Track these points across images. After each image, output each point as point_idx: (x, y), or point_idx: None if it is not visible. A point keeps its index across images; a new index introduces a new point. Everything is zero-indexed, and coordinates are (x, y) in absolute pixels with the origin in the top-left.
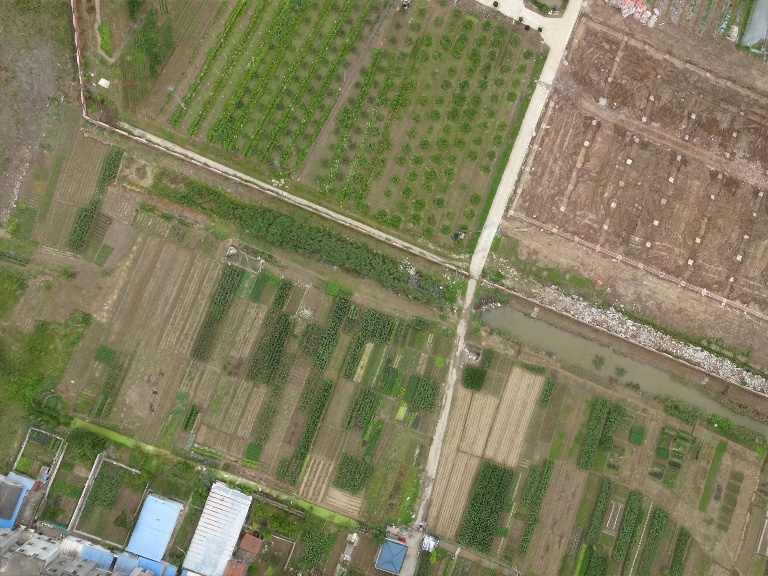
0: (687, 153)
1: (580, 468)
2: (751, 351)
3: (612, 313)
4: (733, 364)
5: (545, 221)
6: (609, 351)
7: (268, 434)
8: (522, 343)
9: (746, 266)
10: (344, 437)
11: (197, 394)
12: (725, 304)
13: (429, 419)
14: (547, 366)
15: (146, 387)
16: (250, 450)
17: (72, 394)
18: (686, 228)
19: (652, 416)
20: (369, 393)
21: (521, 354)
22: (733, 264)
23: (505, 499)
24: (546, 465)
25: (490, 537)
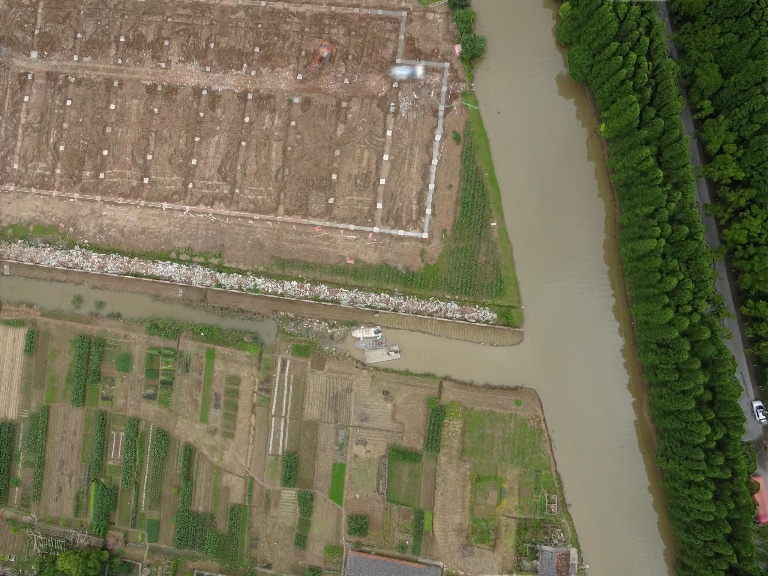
0: (123, 76)
1: (72, 406)
2: (223, 251)
3: (76, 251)
4: (206, 269)
5: (1, 182)
6: (85, 288)
7: None
8: (1, 301)
9: (200, 168)
10: None
11: None
12: (188, 212)
13: None
14: (26, 317)
15: None
16: None
17: None
18: (134, 149)
19: (134, 340)
20: None
21: (1, 312)
22: (189, 170)
23: (7, 451)
24: None
25: None
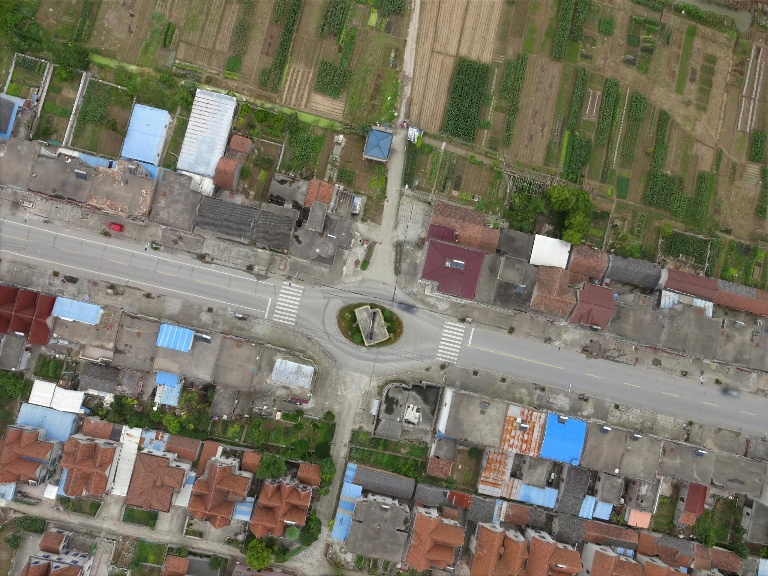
0: None
1: (554, 58)
2: None
3: None
4: None
5: None
6: None
7: (245, 46)
8: None
9: None
10: (320, 45)
11: (172, 14)
12: None
13: (401, 23)
14: None
15: (122, 10)
16: (230, 62)
17: (52, 21)
18: None
19: (619, 6)
20: (339, 0)
21: None
22: None
23: (483, 90)
24: (520, 56)
25: (473, 126)
